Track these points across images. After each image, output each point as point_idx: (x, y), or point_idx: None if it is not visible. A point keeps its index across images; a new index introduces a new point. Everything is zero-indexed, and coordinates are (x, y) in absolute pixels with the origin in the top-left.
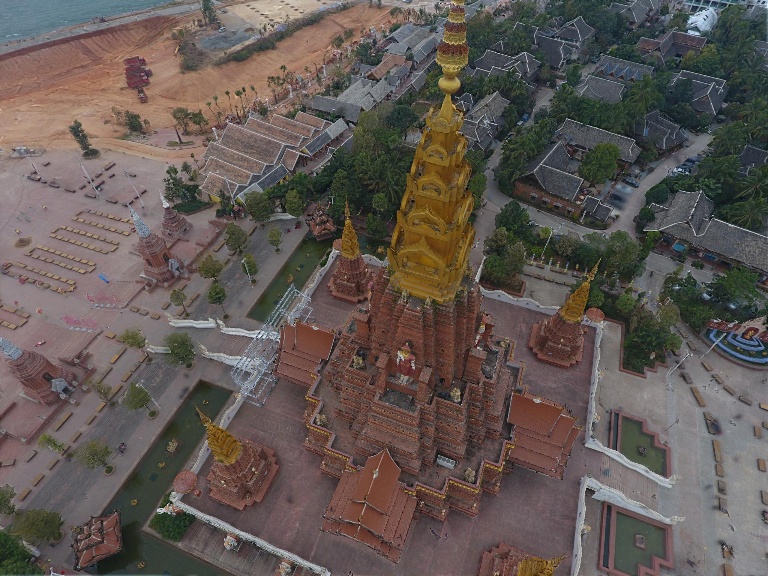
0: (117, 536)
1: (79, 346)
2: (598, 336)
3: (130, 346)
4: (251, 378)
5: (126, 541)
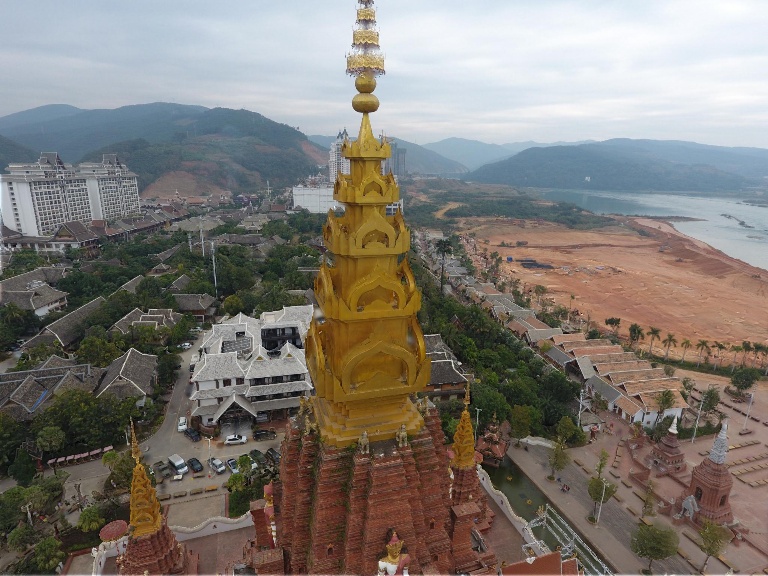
0: (484, 451)
1: (764, 548)
2: None
3: (703, 535)
4: None
5: (484, 466)
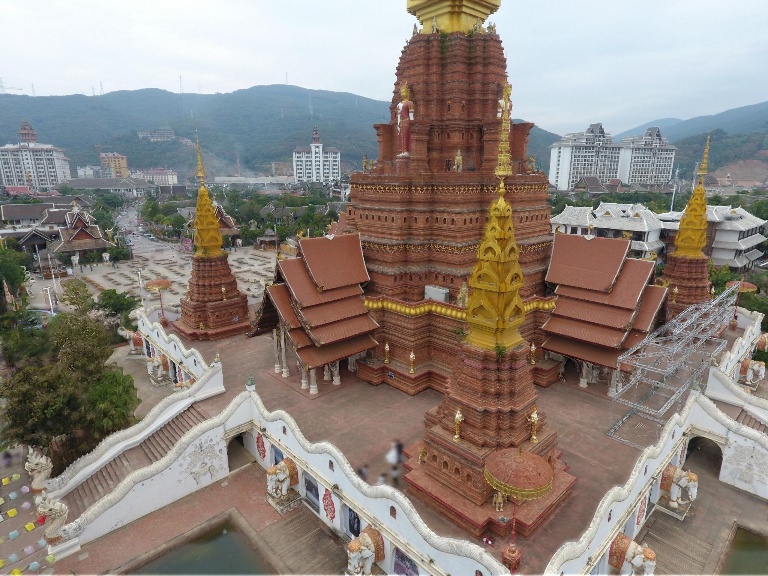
0: None
1: None
2: (169, 308)
3: None
4: (721, 365)
5: None
